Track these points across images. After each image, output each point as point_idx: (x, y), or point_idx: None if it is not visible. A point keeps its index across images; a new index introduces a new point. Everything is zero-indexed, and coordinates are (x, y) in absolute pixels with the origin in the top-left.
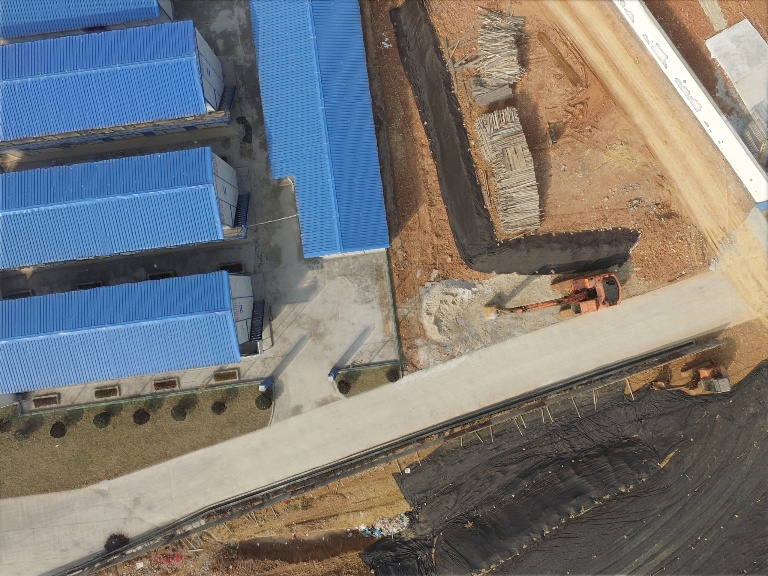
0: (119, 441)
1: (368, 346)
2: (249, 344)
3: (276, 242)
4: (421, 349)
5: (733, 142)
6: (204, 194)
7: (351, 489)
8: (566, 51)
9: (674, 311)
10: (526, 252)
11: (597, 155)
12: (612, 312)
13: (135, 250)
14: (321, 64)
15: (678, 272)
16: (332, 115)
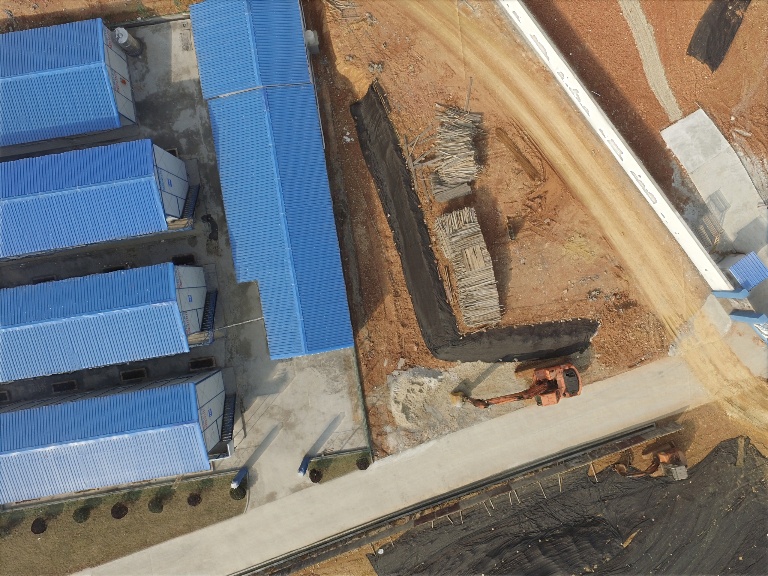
0: (99, 532)
1: (339, 434)
2: (220, 444)
3: (245, 336)
4: (390, 436)
5: (687, 236)
6: (168, 310)
7: (327, 570)
8: (524, 146)
9: (635, 395)
10: (489, 344)
11: (556, 248)
12: (575, 397)
13: (103, 365)
14: (281, 170)
15: (638, 358)
16: (293, 220)
